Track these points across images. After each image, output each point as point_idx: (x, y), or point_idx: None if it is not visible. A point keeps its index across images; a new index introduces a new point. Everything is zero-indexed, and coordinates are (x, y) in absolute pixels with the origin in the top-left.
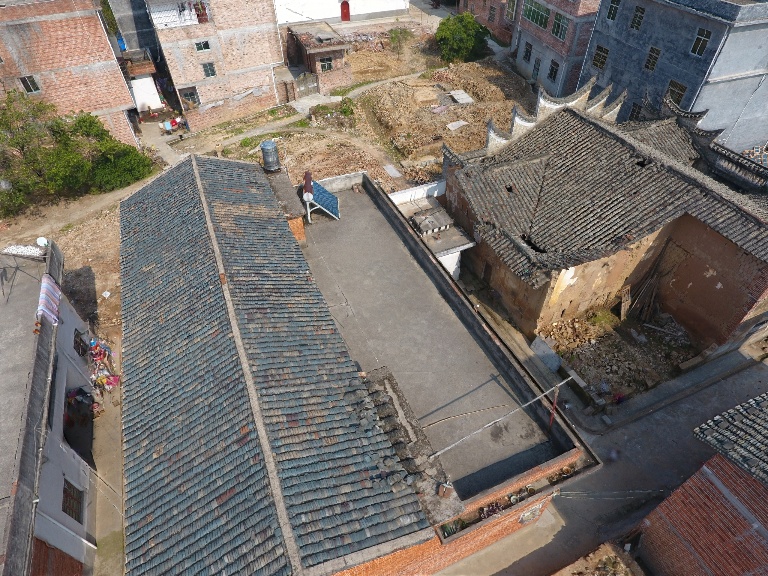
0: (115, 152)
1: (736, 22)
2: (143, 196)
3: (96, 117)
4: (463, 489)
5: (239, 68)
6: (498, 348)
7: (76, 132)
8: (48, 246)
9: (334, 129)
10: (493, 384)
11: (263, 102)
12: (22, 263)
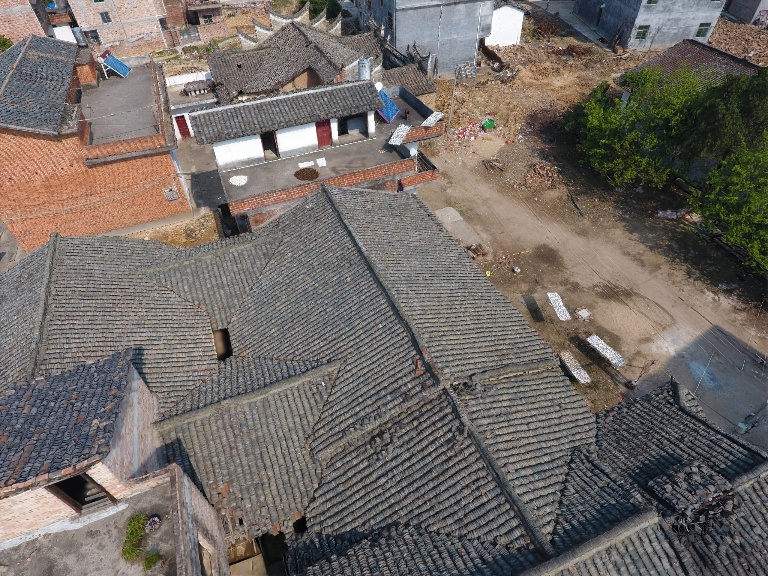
0: None
1: None
2: (2, 55)
3: (9, 39)
4: None
5: (131, 18)
6: None
7: None
8: None
9: (196, 60)
10: (152, 127)
11: (154, 46)
12: None
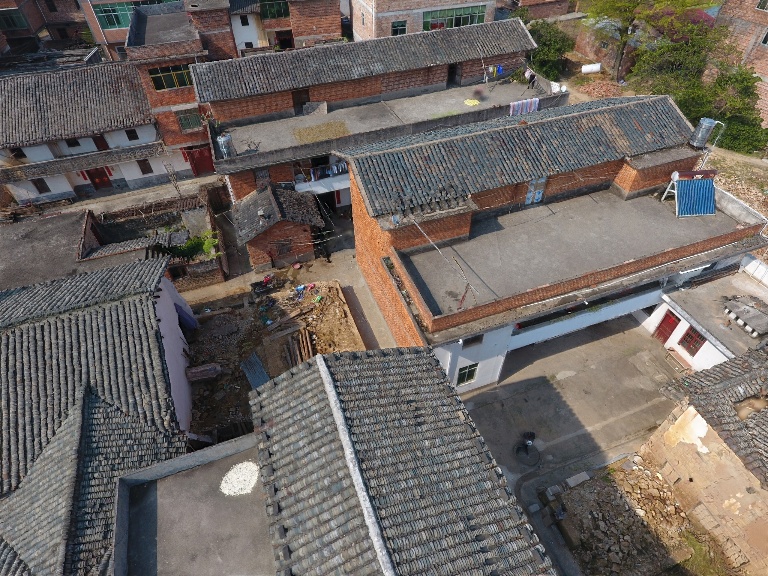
0: (740, 115)
1: None
2: None
3: (757, 79)
4: (411, 271)
5: None
6: None
7: None
8: (562, 93)
9: None
10: None
11: None
12: None
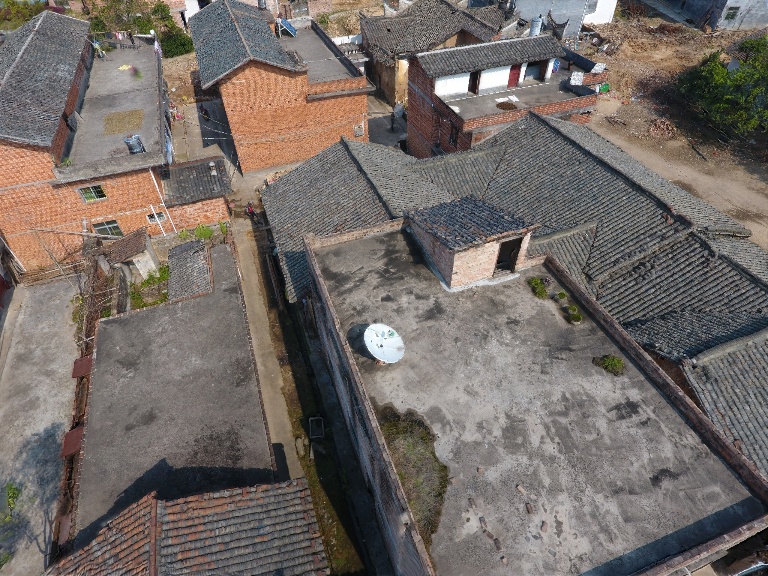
0: (176, 31)
1: None
2: (199, 14)
3: None
4: None
5: None
6: (348, 60)
7: (155, 13)
8: (155, 35)
9: None
10: (345, 74)
11: None
12: (142, 44)
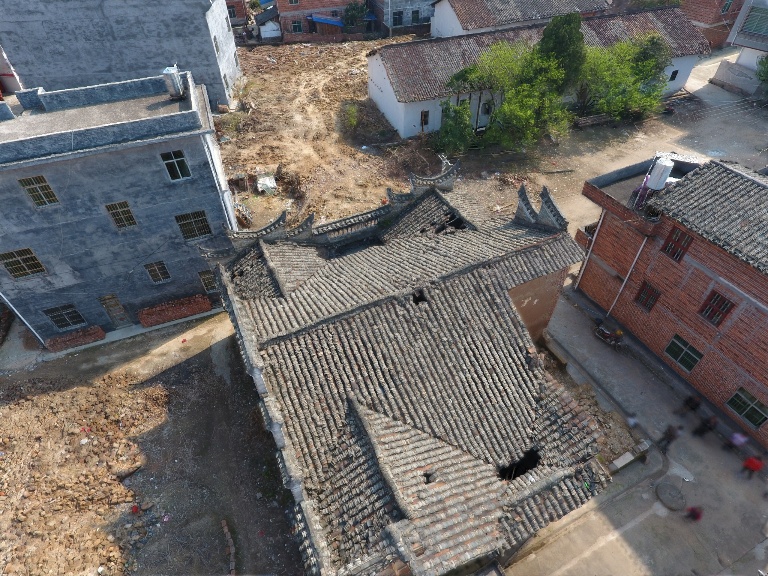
0: None
1: (205, 127)
2: None
3: None
4: None
5: None
6: None
7: None
8: None
9: None
10: None
11: None
12: None
